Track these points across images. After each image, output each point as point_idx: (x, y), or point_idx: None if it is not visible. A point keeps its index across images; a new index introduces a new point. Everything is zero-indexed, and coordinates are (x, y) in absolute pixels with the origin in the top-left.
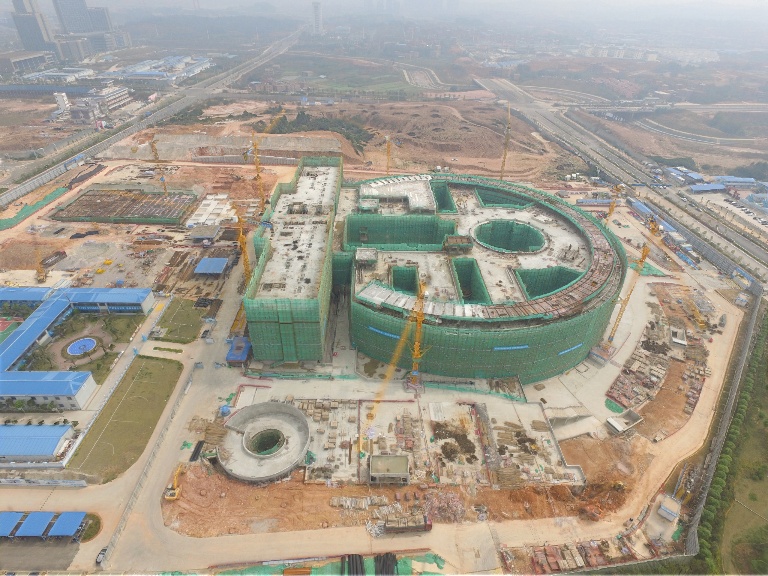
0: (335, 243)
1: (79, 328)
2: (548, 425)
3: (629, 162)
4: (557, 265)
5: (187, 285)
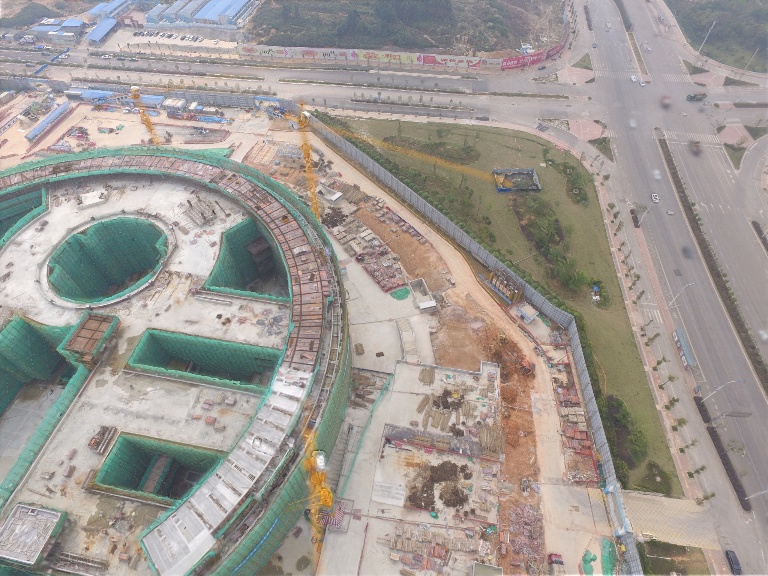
0: None
1: None
2: (427, 367)
3: None
4: (218, 235)
5: None
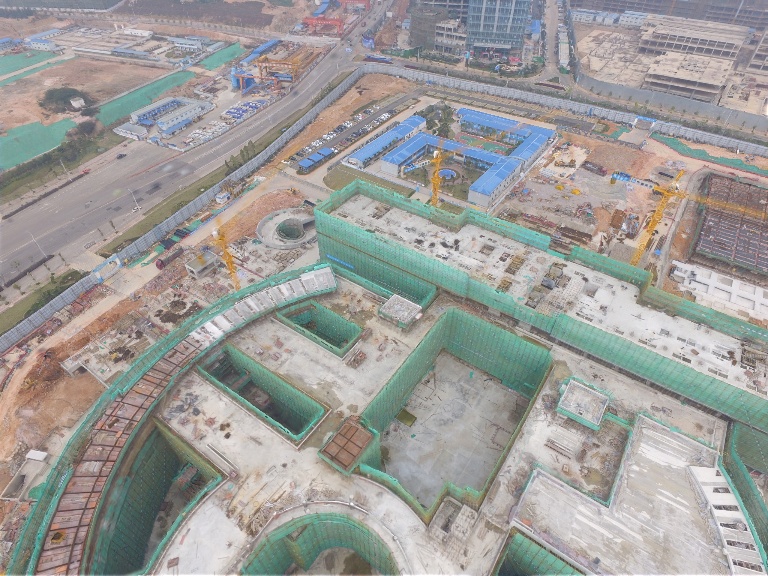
0: (476, 315)
1: (472, 175)
2: (108, 384)
3: None
4: None
5: None
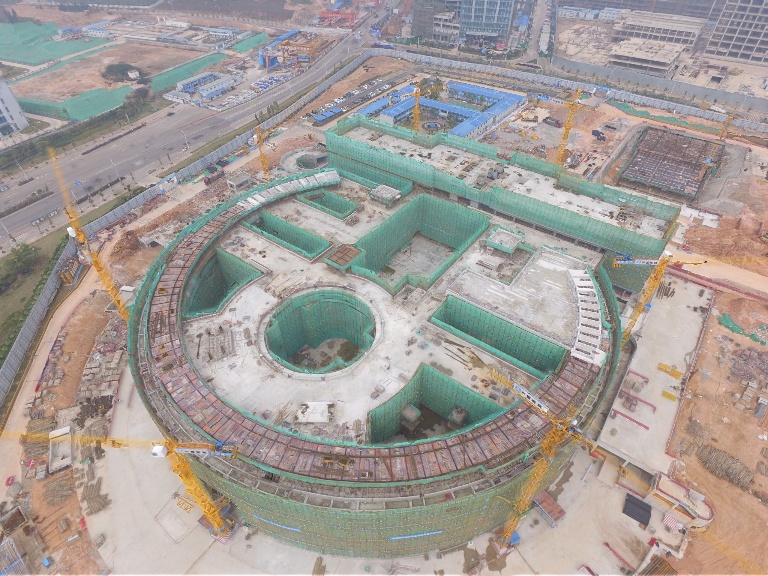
0: None
1: (453, 126)
2: None
3: None
4: None
5: None
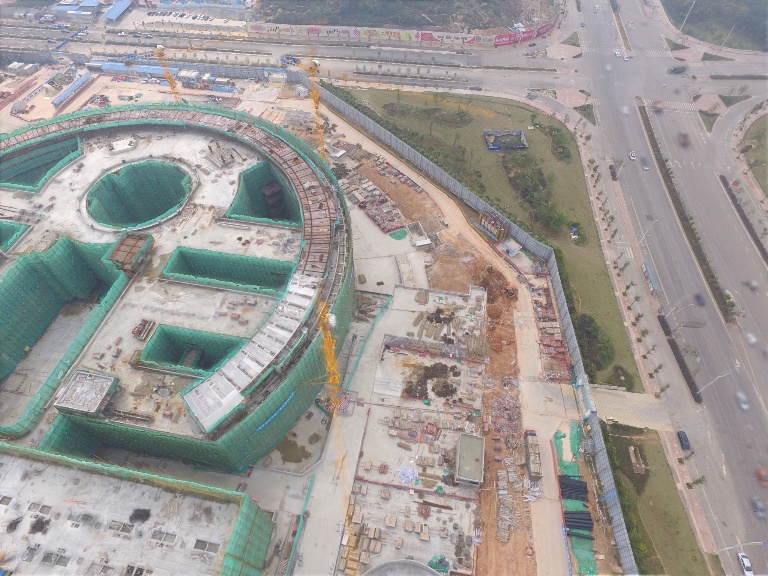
0: None
1: None
2: (422, 291)
3: (1, 24)
4: None
5: None
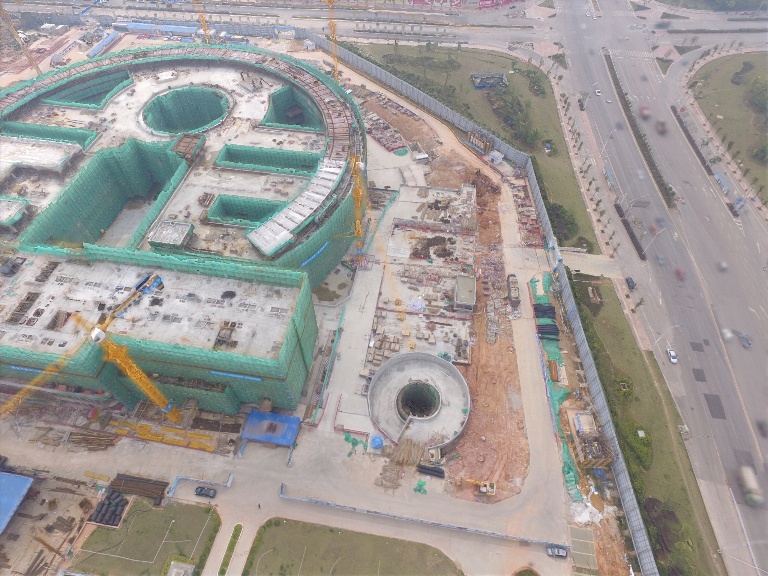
0: None
1: None
2: (423, 188)
3: None
4: None
5: (24, 557)
